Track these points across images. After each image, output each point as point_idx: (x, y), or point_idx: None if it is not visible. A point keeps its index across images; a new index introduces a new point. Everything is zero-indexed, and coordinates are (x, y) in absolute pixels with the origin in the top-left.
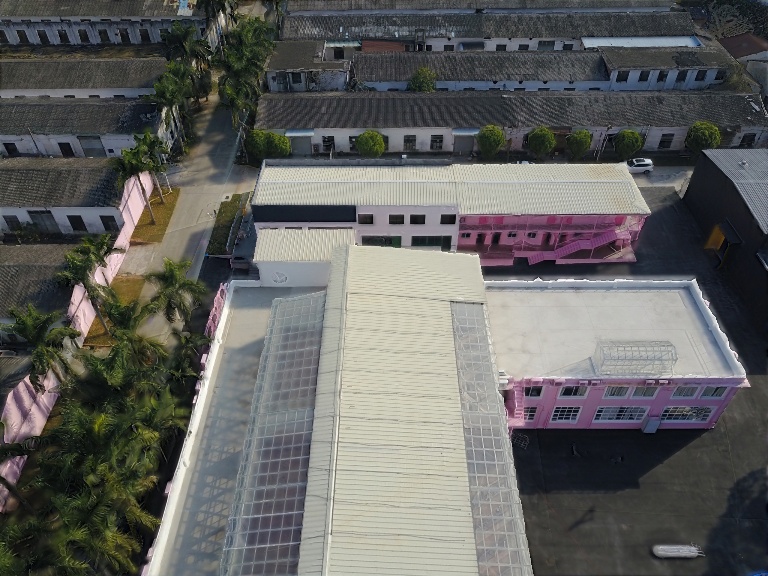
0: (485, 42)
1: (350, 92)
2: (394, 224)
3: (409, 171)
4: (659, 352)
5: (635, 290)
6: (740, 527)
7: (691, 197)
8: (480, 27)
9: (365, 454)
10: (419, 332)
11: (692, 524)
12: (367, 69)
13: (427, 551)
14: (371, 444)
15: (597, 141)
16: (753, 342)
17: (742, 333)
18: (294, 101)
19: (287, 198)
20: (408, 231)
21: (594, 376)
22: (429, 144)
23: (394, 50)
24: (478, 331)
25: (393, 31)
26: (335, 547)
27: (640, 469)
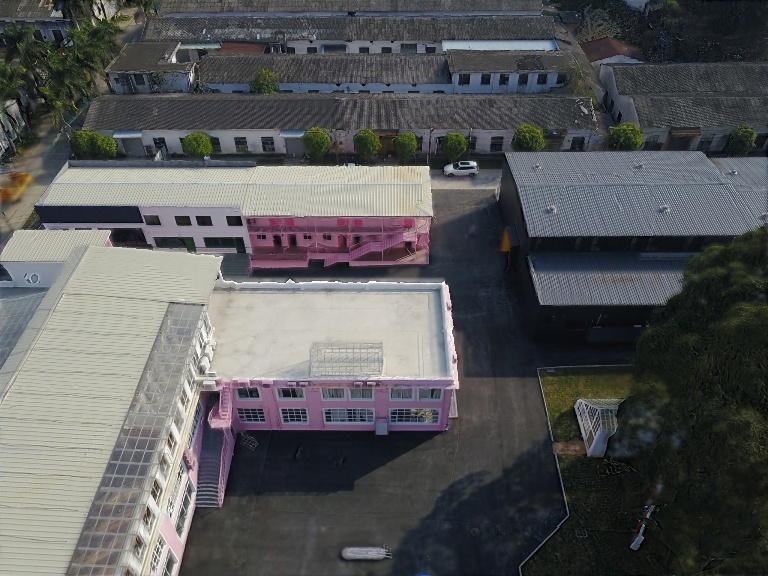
0: (347, 45)
1: (191, 94)
2: (182, 225)
3: (209, 173)
4: (366, 354)
5: (386, 292)
6: (438, 529)
7: (501, 200)
8: (342, 30)
9: (3, 454)
10: (121, 333)
11: (392, 526)
12: (212, 71)
13: (21, 552)
14: (15, 445)
15: (428, 144)
16: (516, 344)
17: (508, 335)
18: (127, 102)
19: (76, 199)
20: (198, 232)
21: (307, 378)
22: (261, 146)
23: (252, 52)
24: (186, 332)
25: (255, 33)
26: None
27: (360, 471)
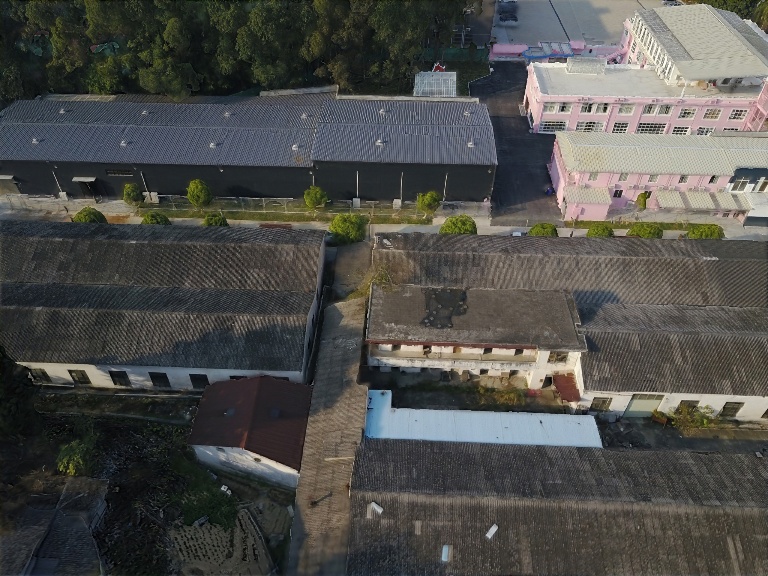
0: None
1: None
2: None
3: None
4: None
5: None
6: None
7: None
8: None
9: None
10: None
11: None
12: None
13: None
14: None
15: None
16: None
17: None
18: None
19: None
20: None
21: None
22: None
23: None
24: None
25: None
26: (704, 7)
27: None
